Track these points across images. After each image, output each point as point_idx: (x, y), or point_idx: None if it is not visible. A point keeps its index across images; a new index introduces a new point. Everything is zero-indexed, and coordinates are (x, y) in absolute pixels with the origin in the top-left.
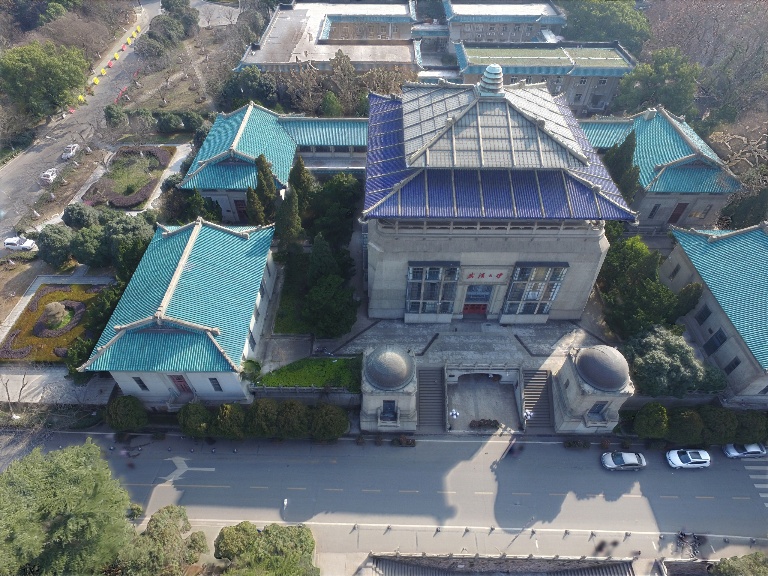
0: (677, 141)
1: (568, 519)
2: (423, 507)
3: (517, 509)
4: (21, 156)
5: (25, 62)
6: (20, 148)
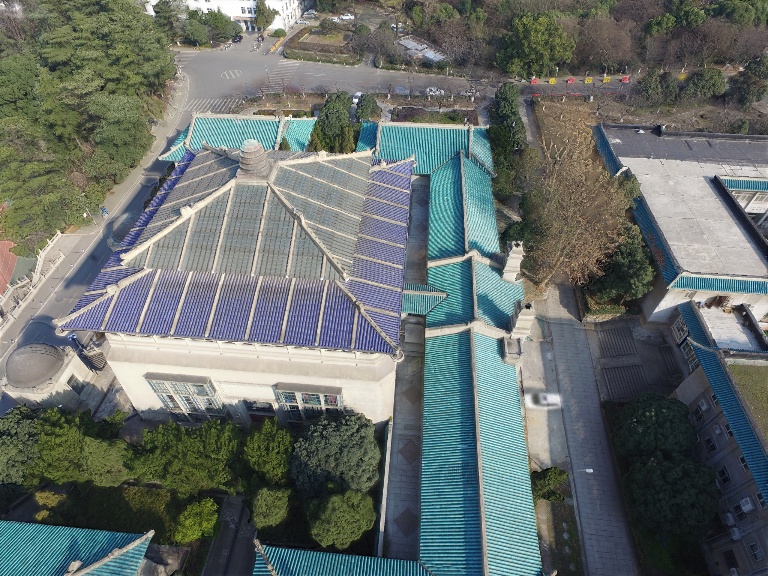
0: None
1: (4, 367)
2: (72, 283)
3: (34, 337)
4: (465, 79)
5: (525, 27)
6: (471, 75)
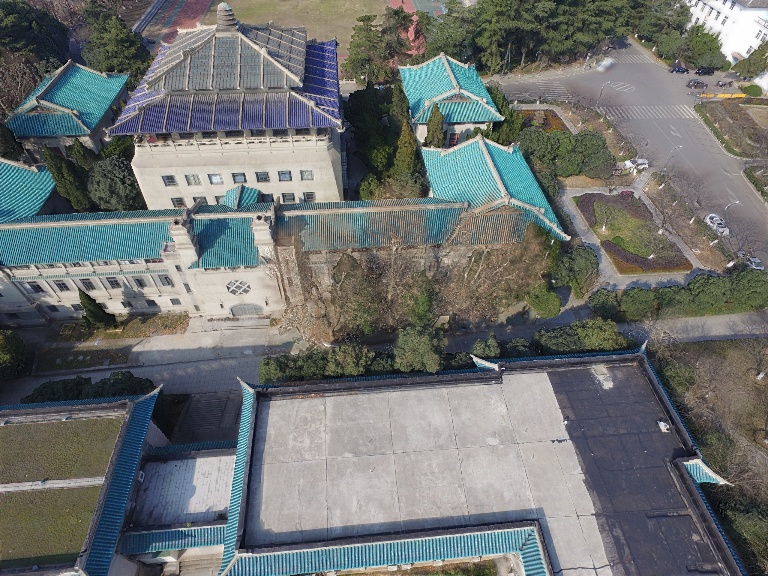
0: None
1: None
2: None
3: None
4: None
5: None
6: None
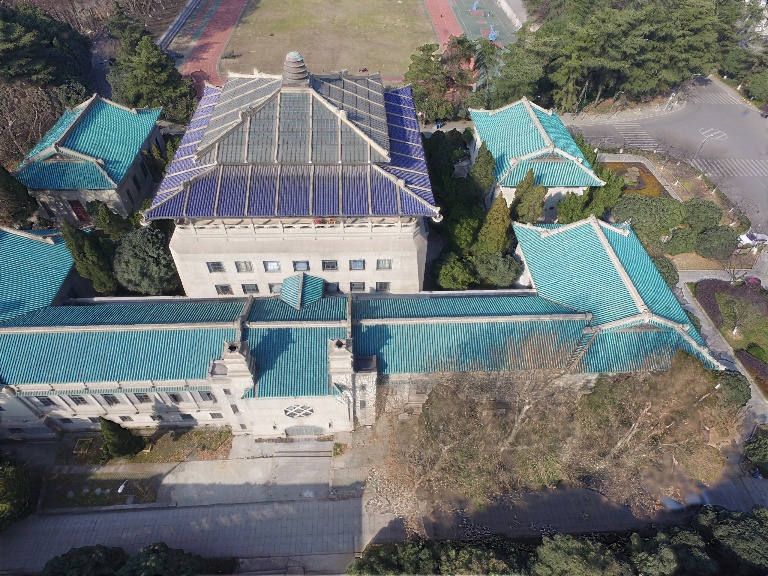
0: None
1: None
2: None
3: None
4: None
5: None
6: None
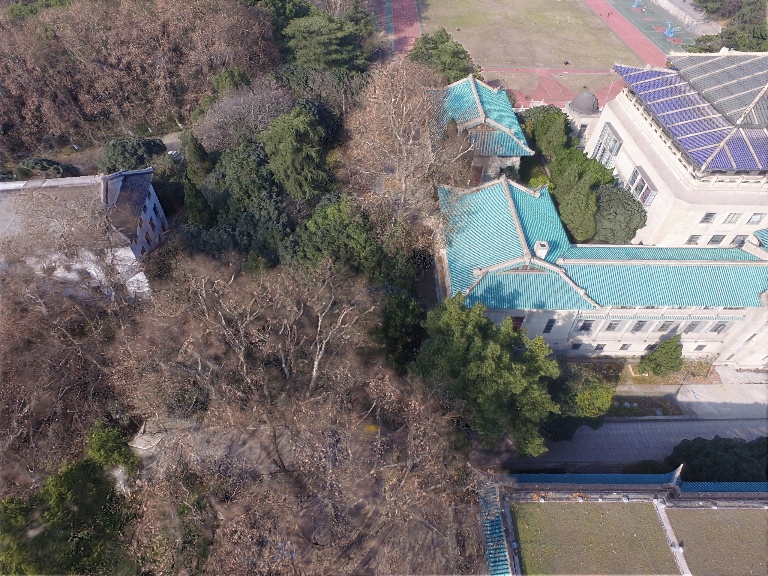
0: (517, 205)
1: None
2: None
3: None
4: None
5: None
6: None
